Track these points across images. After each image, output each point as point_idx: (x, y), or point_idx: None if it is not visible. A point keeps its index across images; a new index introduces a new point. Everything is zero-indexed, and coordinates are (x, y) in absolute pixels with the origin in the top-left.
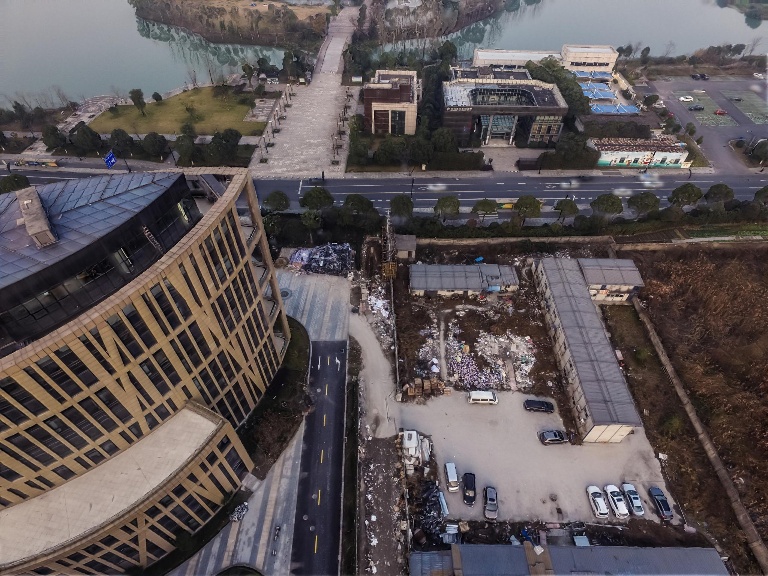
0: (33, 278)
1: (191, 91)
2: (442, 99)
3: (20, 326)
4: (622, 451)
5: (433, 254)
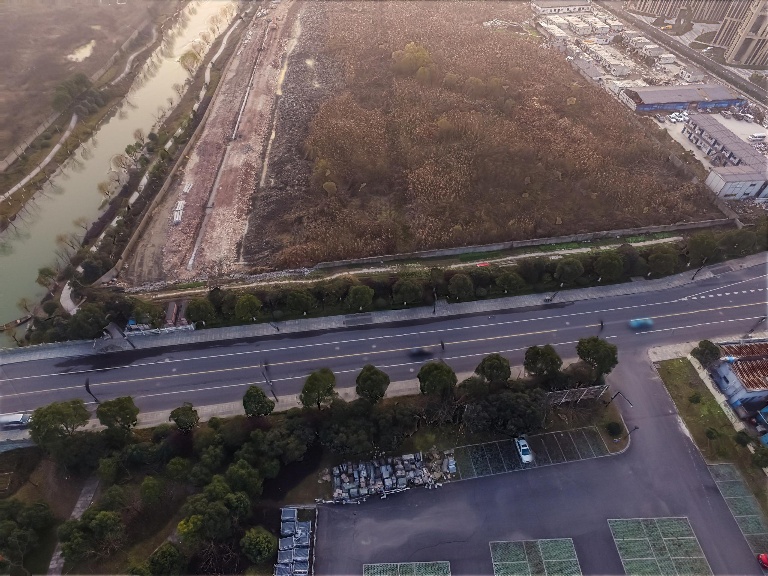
0: None
1: None
2: None
3: None
4: (679, 130)
5: None
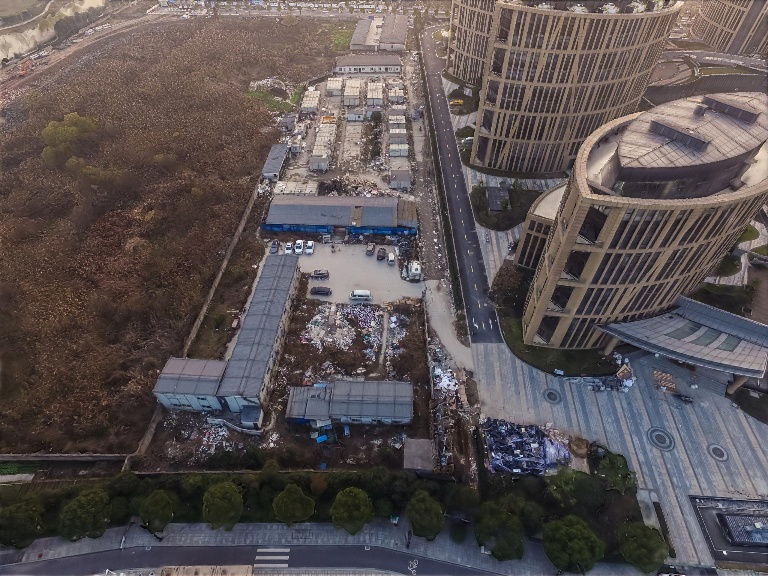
0: None
1: None
2: None
3: None
4: None
5: None
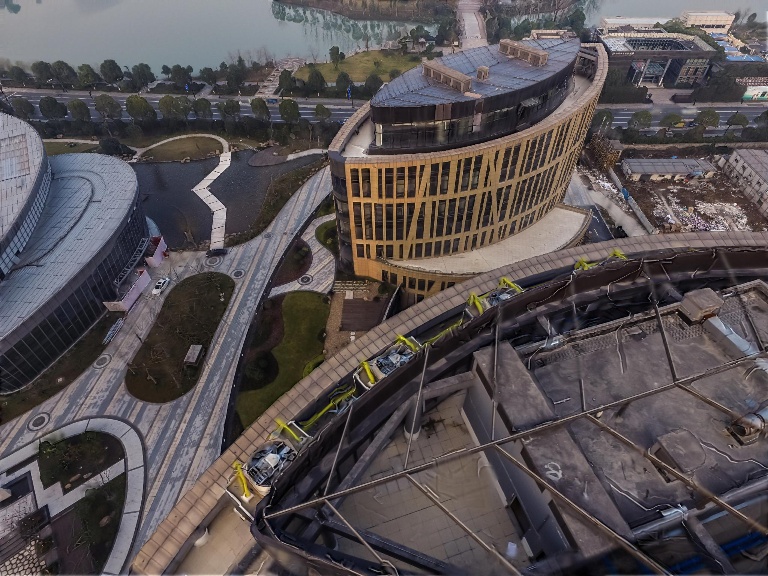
0: (552, 78)
1: (361, 53)
2: None
3: (532, 112)
4: None
5: (633, 156)
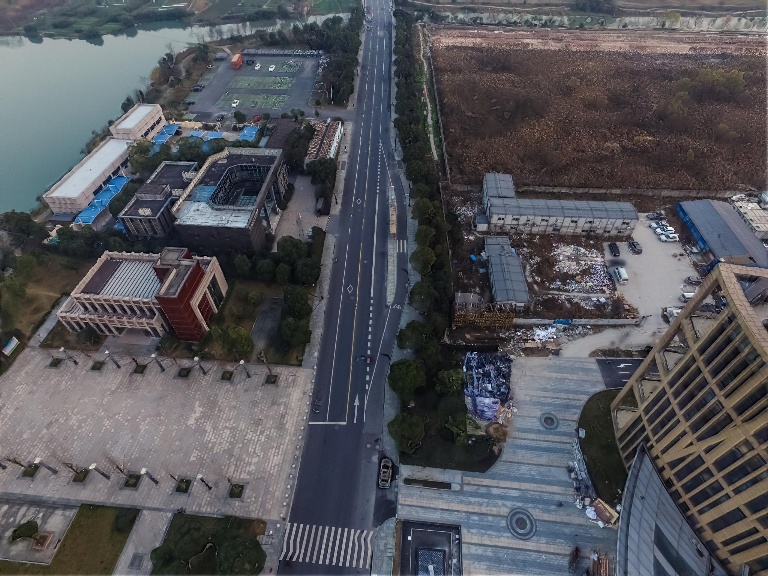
0: None
1: None
2: (206, 235)
3: None
4: None
5: None
